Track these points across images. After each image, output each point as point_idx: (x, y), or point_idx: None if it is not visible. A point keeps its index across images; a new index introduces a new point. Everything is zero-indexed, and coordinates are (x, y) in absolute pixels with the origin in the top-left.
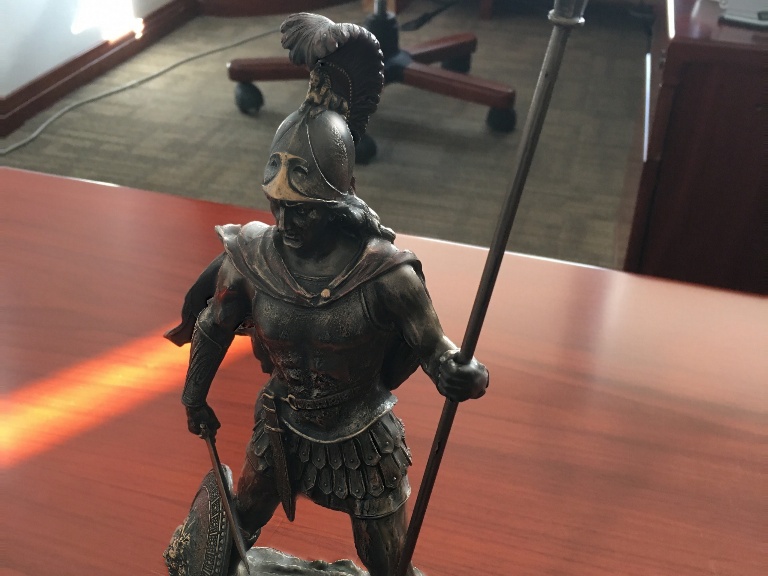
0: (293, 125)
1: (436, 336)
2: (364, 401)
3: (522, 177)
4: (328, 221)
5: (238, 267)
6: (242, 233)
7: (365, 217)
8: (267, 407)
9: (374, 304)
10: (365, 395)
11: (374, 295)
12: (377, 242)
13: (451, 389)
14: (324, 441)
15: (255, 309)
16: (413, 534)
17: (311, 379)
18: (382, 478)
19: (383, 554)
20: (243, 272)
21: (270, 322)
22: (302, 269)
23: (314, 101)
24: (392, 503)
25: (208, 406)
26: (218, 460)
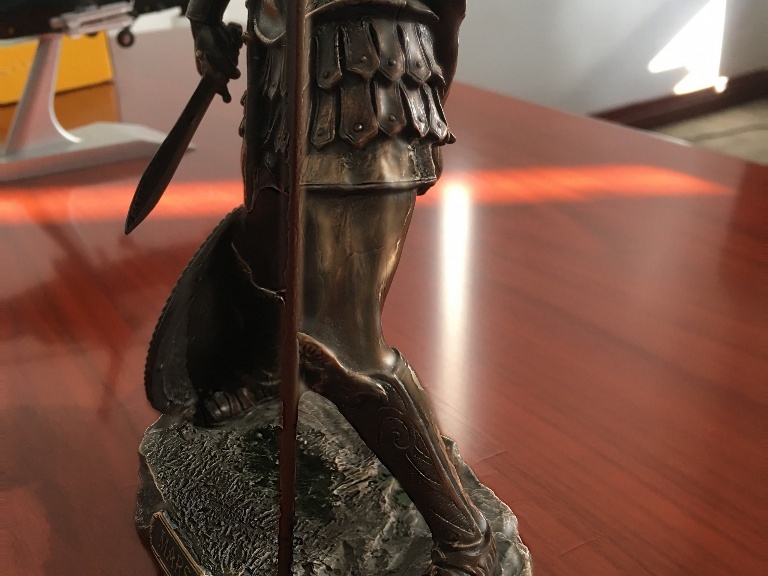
0: None
1: None
2: None
3: None
4: None
5: None
6: None
7: None
8: None
9: None
10: None
11: None
12: None
13: None
14: (275, 38)
15: None
16: (291, 167)
17: None
18: (337, 118)
19: (315, 269)
20: None
21: None
22: None
23: None
24: (345, 172)
25: (219, 32)
26: (198, 103)
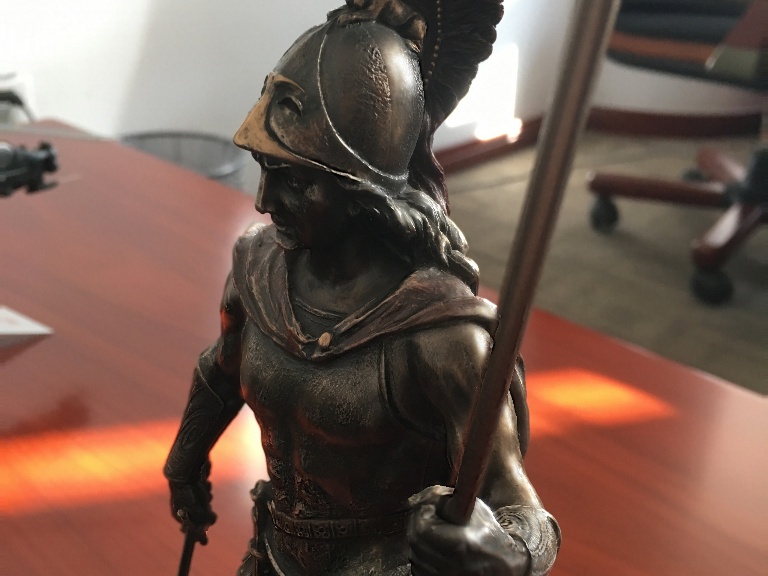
0: (307, 33)
1: (498, 466)
2: (377, 548)
3: (583, 82)
4: (347, 214)
5: (235, 275)
6: (264, 229)
7: (424, 227)
8: (252, 511)
9: (402, 379)
10: (382, 538)
11: (404, 363)
12: (434, 274)
13: (419, 567)
14: None
15: (243, 346)
16: None
17: (295, 482)
18: None
19: None
20: (238, 284)
21: (250, 370)
22: (311, 295)
23: (354, 1)
24: None
25: (199, 486)
26: (185, 571)
